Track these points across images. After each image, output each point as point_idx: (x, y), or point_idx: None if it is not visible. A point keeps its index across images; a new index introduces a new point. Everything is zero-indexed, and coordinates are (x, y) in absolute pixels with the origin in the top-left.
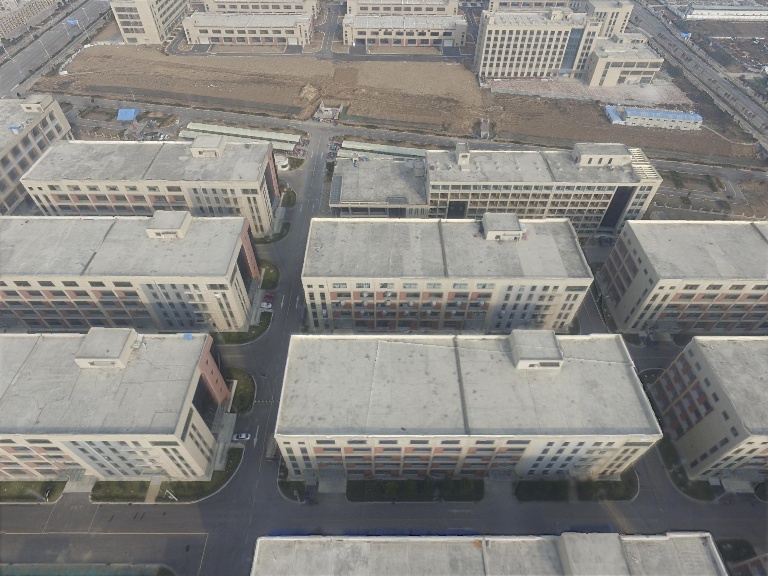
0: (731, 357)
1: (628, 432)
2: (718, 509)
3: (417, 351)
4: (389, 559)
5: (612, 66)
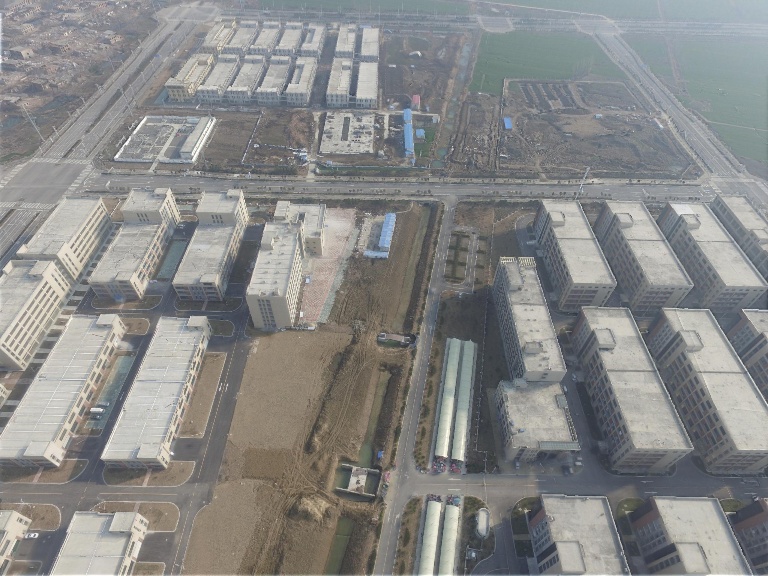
0: (654, 277)
1: (711, 319)
2: None
3: (713, 389)
4: None
5: (322, 234)
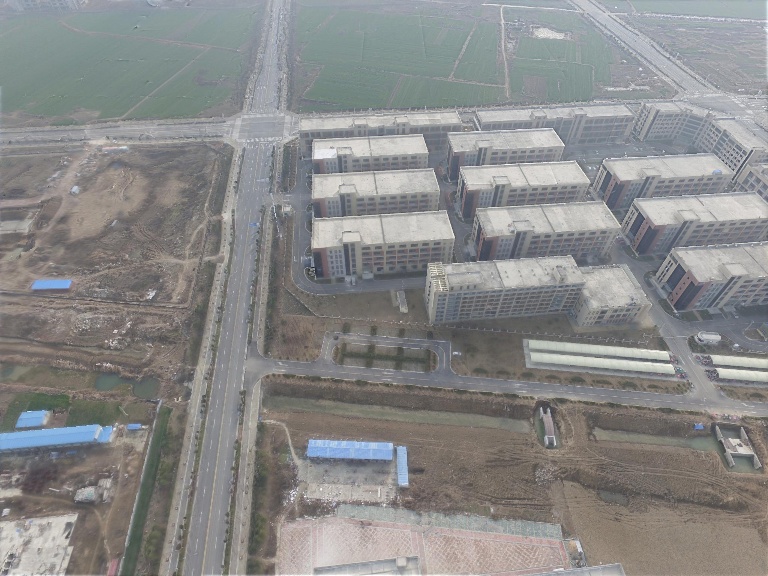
0: (428, 188)
1: None
2: None
3: None
4: (532, 146)
5: None
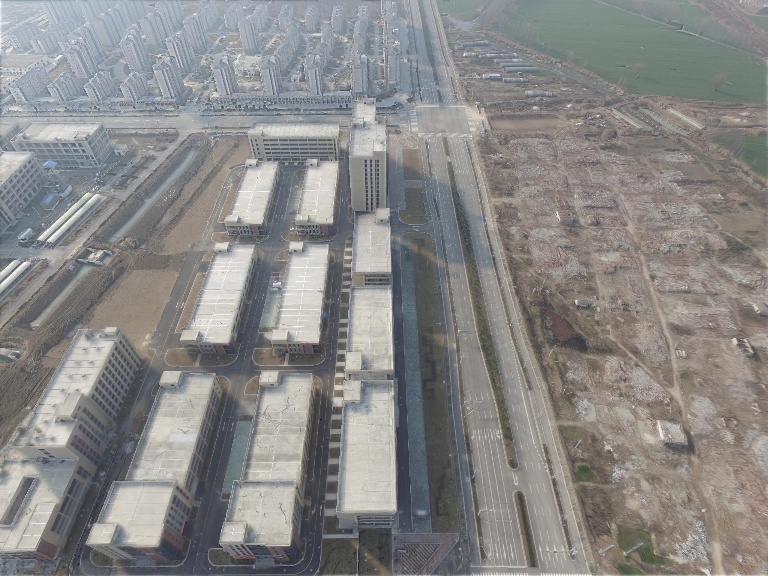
0: None
1: None
2: None
3: None
4: None
5: None
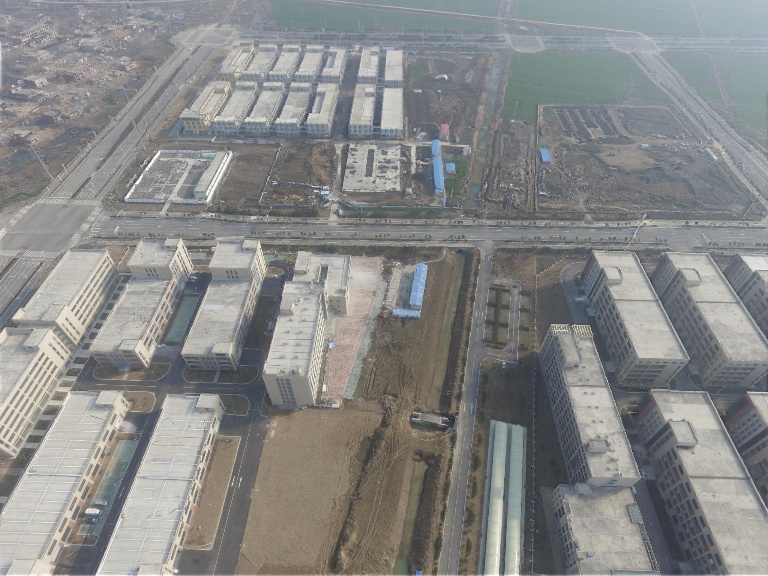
0: (733, 350)
1: None
2: (764, 382)
3: None
4: None
5: (347, 291)
